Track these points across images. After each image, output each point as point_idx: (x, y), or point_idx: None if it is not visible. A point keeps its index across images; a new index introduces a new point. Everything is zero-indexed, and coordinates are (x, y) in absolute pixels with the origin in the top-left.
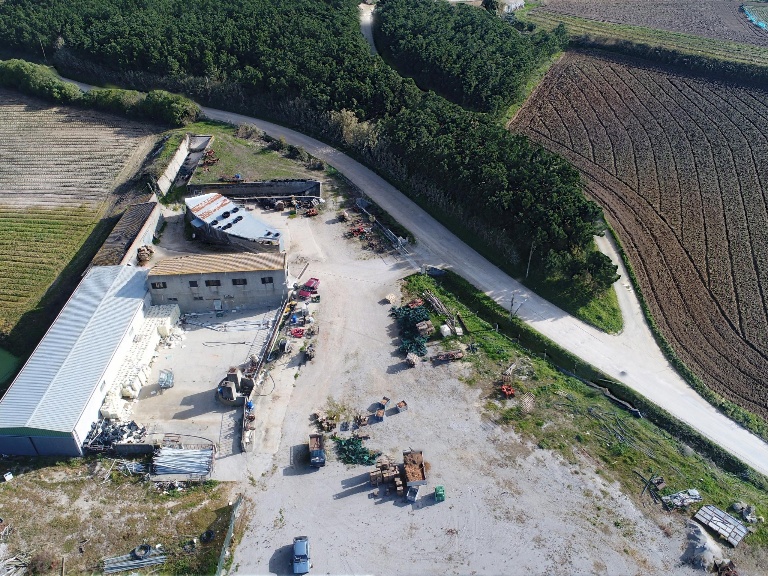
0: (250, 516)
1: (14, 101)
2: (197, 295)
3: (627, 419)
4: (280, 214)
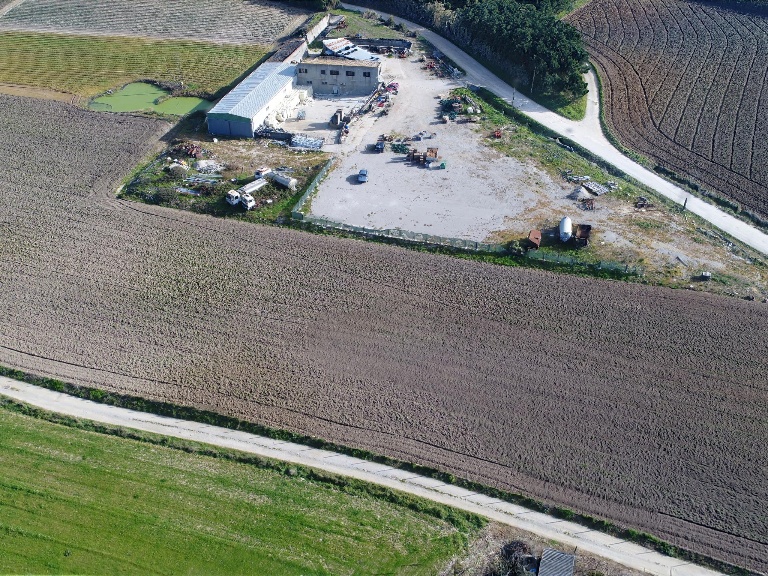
0: (339, 164)
1: None
2: (324, 81)
3: (564, 151)
4: (382, 55)
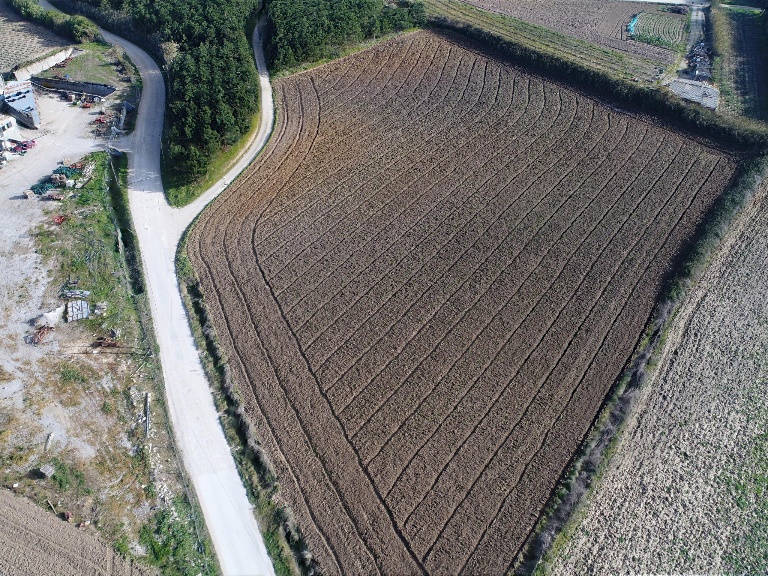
0: None
1: (3, 15)
2: None
3: (108, 251)
4: (67, 103)
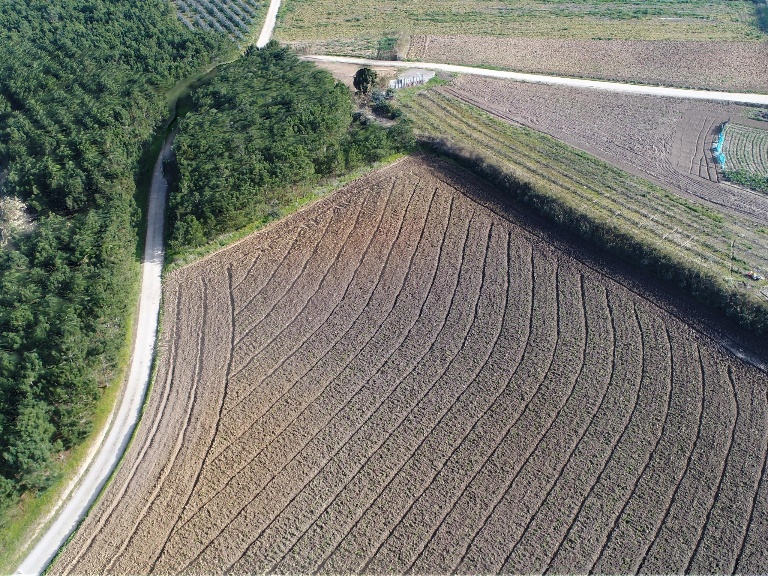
0: None
1: None
2: None
3: None
4: None
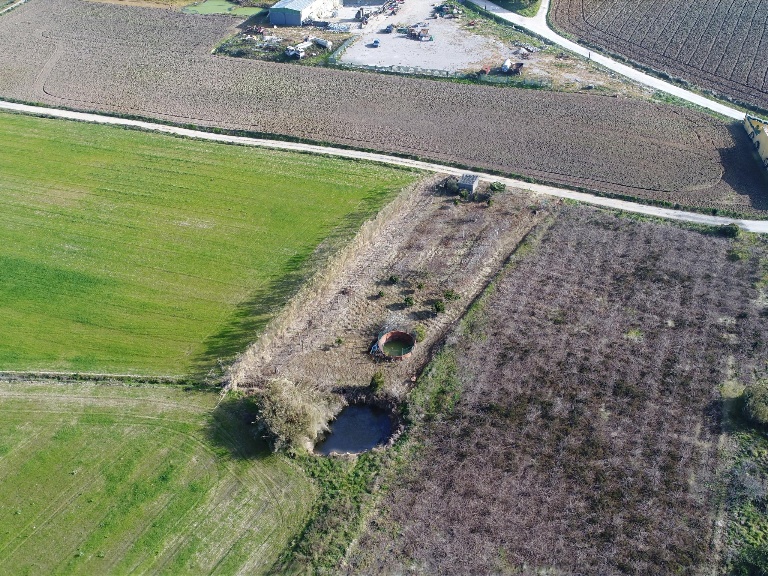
0: (361, 38)
1: None
2: None
3: None
4: None
